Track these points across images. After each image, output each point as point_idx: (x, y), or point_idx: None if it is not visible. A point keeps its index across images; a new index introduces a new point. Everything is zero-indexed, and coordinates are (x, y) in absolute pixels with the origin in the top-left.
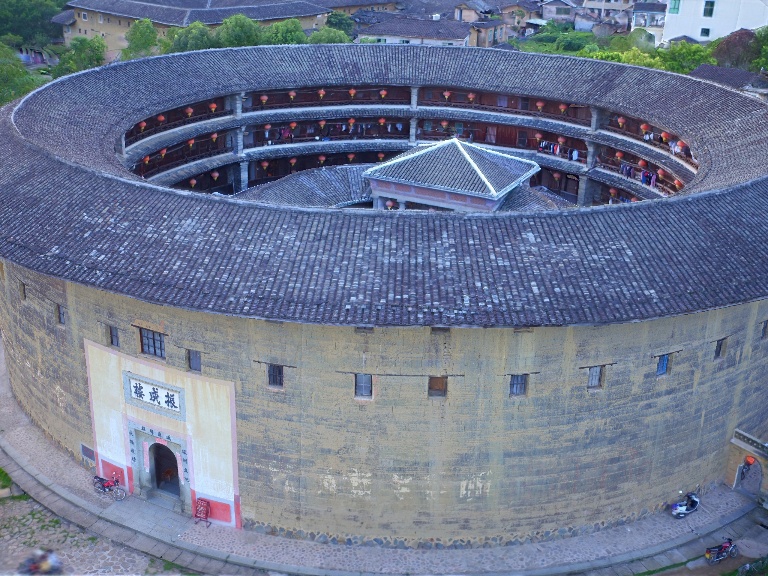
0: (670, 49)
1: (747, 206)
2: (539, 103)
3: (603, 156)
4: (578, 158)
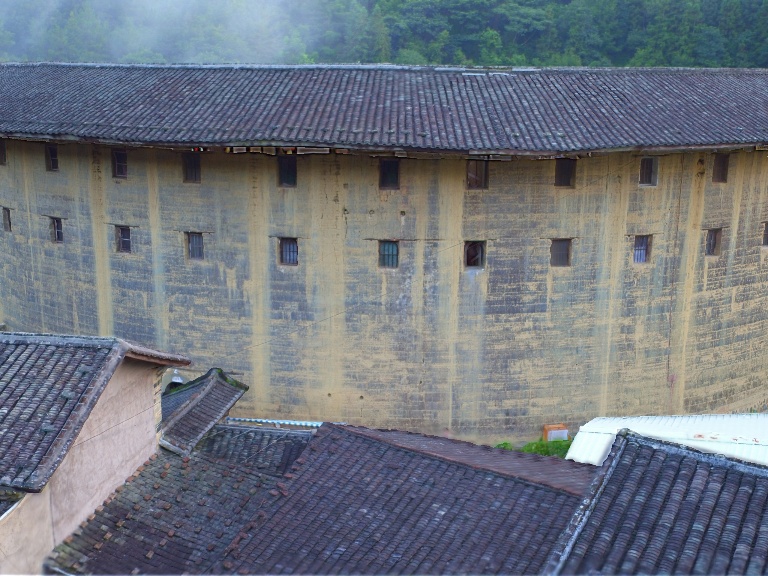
0: None
1: (3, 76)
2: None
3: None
4: None
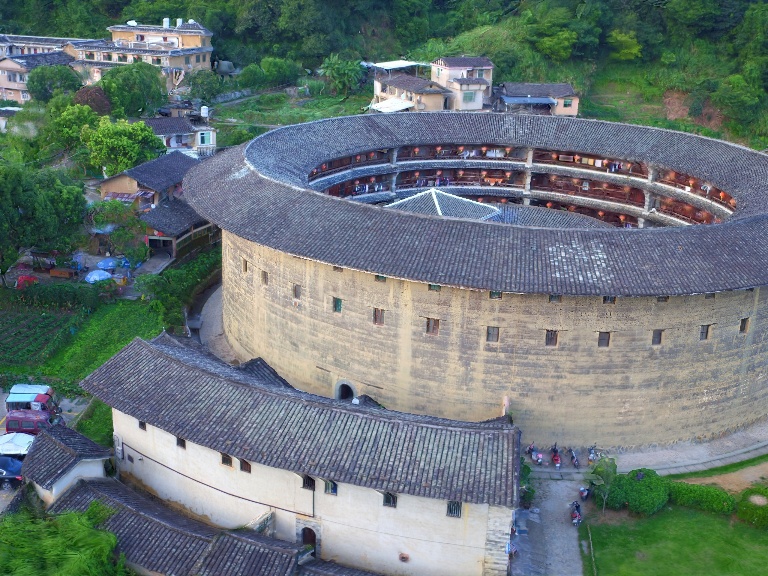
0: (77, 114)
1: None
2: (359, 157)
3: (398, 180)
4: (381, 189)
